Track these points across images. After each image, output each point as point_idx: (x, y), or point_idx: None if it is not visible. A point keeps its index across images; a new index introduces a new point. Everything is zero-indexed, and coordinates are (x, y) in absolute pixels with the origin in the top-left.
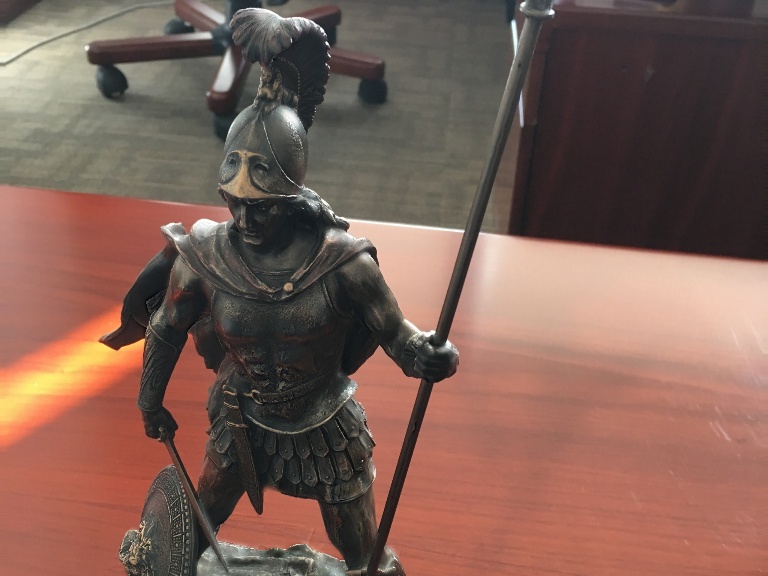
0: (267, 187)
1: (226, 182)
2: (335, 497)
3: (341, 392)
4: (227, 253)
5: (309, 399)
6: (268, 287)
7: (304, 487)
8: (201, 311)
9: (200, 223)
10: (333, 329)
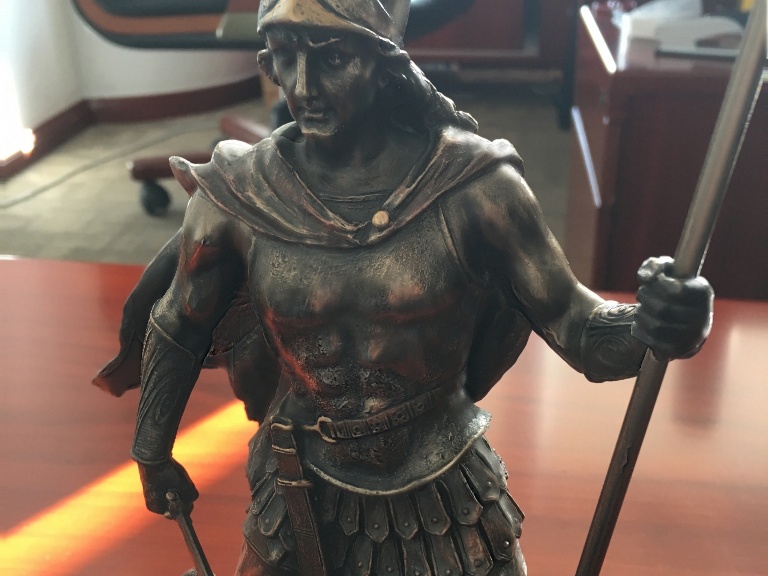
0: (344, 8)
1: (271, 7)
2: None
3: (468, 421)
4: (275, 172)
5: (415, 430)
6: (345, 221)
7: None
8: (233, 289)
9: (232, 142)
10: (457, 299)
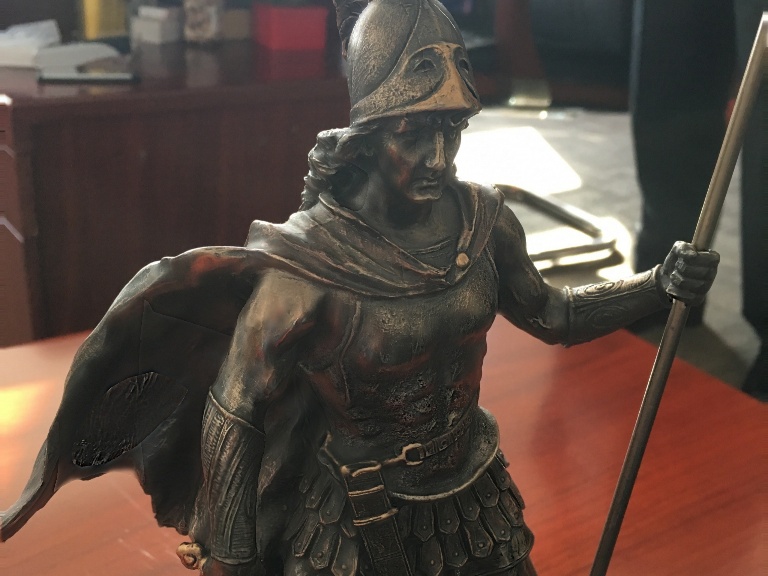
0: (477, 93)
1: (424, 96)
2: (514, 556)
3: (481, 410)
4: (359, 240)
5: (470, 429)
6: (437, 268)
7: (462, 568)
8: (297, 361)
9: None
10: None
